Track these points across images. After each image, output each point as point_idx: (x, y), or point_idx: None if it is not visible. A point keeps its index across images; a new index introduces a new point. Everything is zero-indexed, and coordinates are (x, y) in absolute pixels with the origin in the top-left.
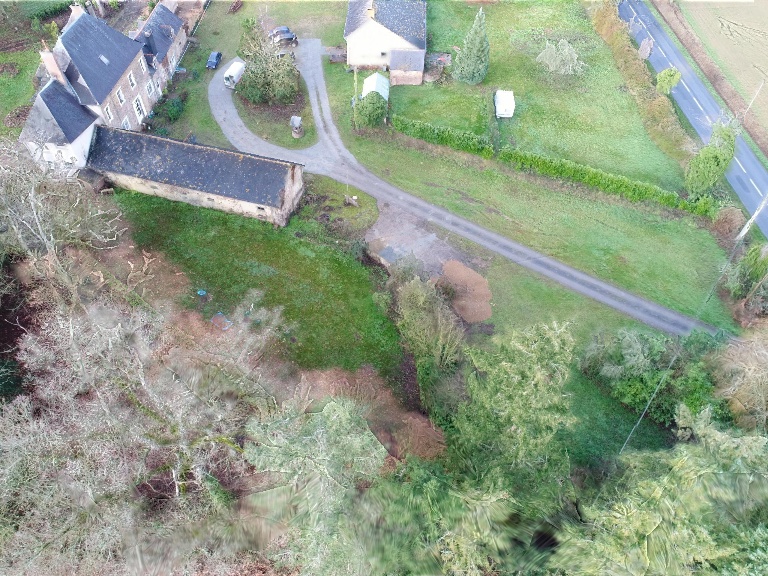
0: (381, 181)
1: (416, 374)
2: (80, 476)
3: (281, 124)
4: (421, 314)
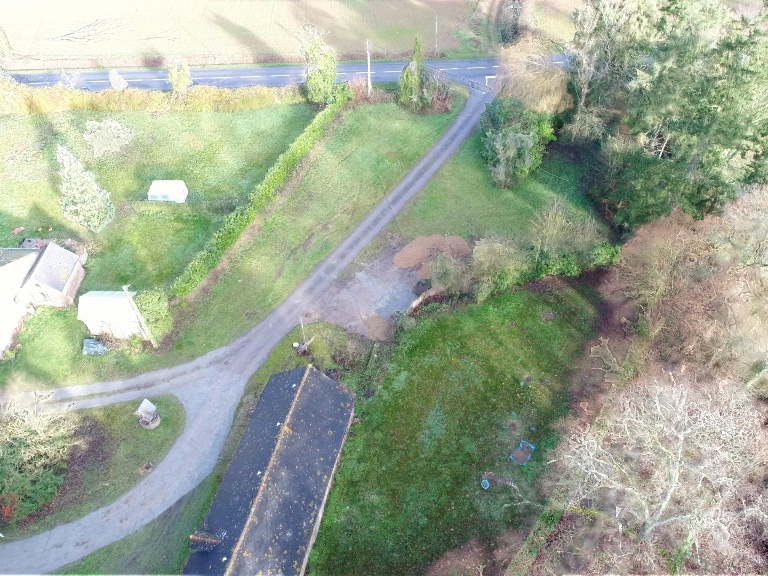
0: (266, 320)
1: (543, 281)
2: (761, 553)
3: (118, 448)
4: (511, 253)
